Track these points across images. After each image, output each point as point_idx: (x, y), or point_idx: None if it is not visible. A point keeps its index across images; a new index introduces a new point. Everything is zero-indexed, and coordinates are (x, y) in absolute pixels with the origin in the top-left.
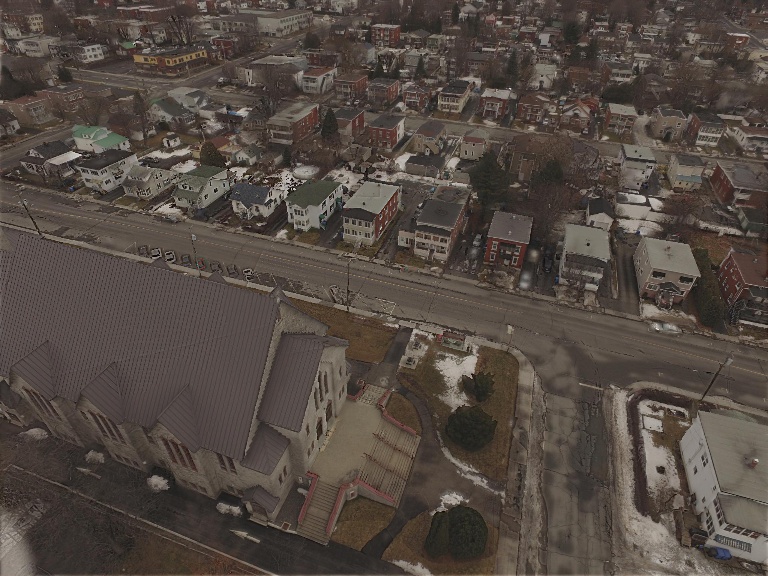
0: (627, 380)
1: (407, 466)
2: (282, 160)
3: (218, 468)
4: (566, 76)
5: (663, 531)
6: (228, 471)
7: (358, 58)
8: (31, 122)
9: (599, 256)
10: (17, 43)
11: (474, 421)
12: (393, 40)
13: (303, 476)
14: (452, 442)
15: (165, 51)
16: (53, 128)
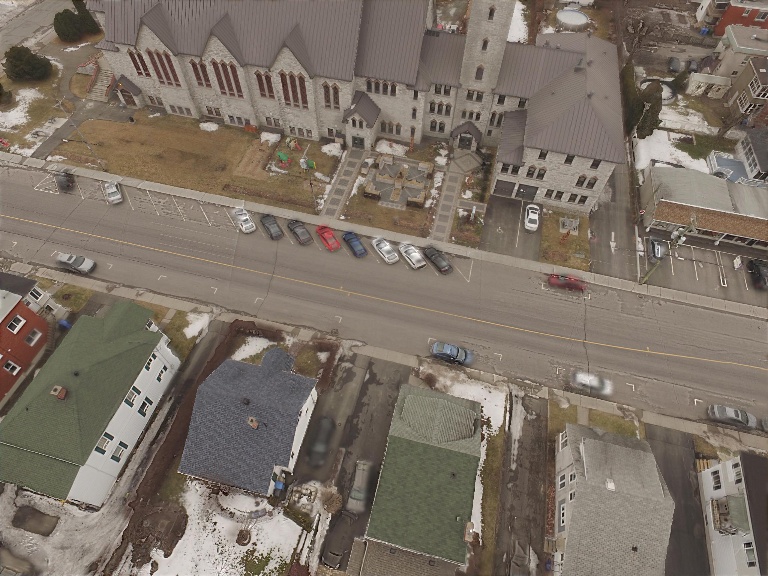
0: None
1: None
2: None
3: None
4: None
5: None
6: None
7: None
8: None
9: None
10: None
11: None
12: None
13: None
14: None
15: None
16: None
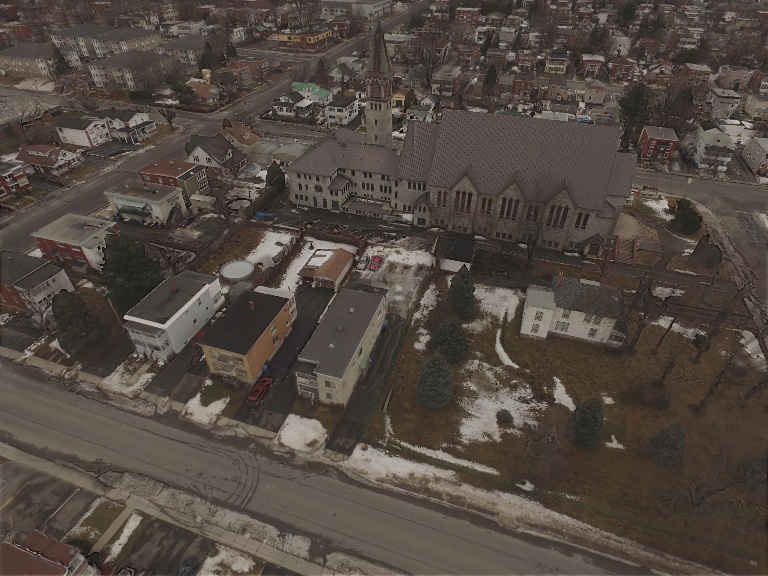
0: (764, 209)
1: (657, 239)
2: (454, 105)
3: (572, 228)
4: (638, 46)
5: None
6: (579, 228)
7: (464, 34)
8: (241, 84)
9: (729, 146)
10: (171, 27)
11: (692, 215)
12: (475, 21)
13: (609, 238)
14: (676, 232)
15: (301, 31)
16: (259, 88)
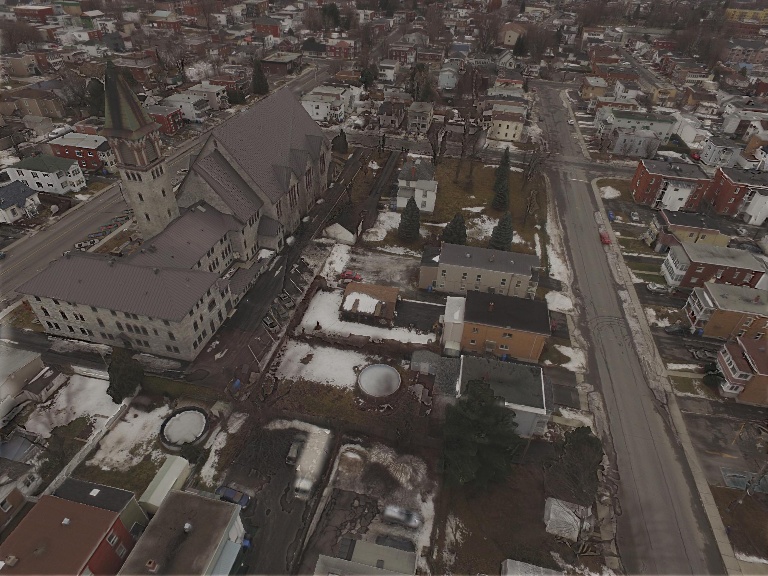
0: None
1: None
2: None
3: None
4: None
5: None
6: None
7: None
8: None
9: None
10: None
11: None
12: None
13: None
14: None
15: None
16: None
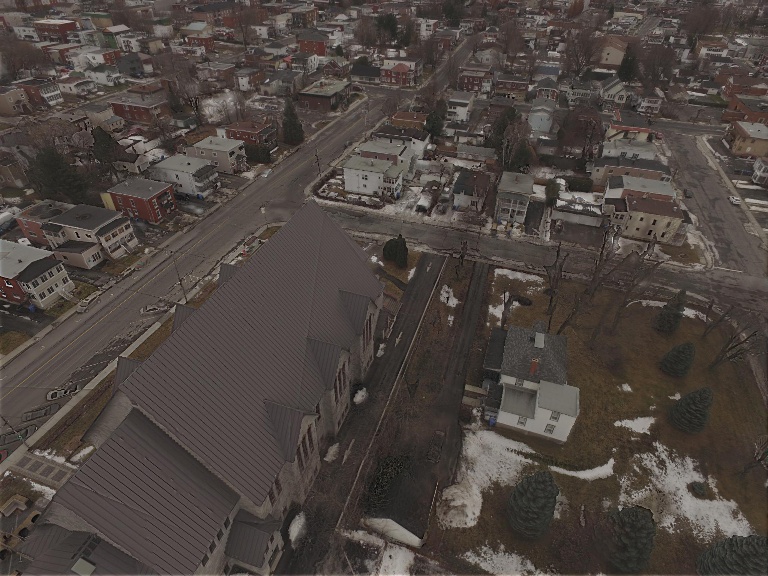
0: (302, 195)
1: None
2: None
3: None
4: None
5: (389, 205)
6: None
7: None
8: None
9: (206, 163)
10: None
11: None
12: None
13: None
14: None
15: None
16: None
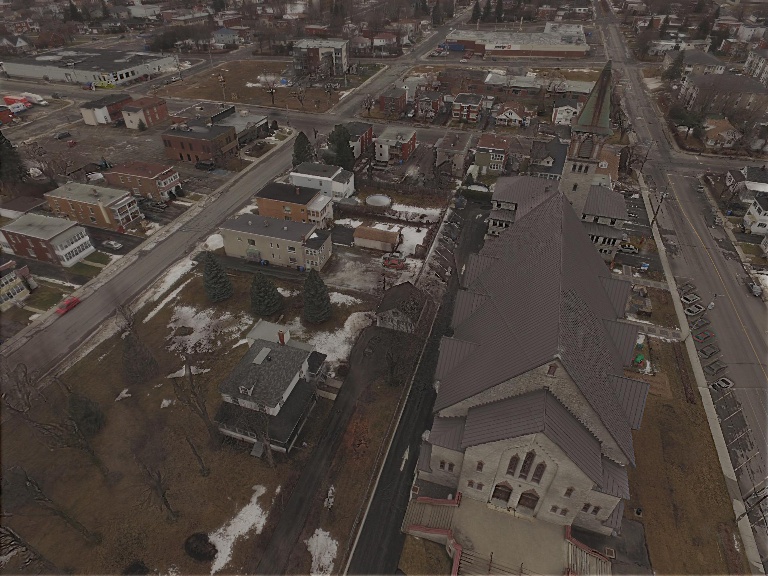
0: None
1: None
2: None
3: None
4: None
5: None
6: None
7: None
8: None
9: None
10: None
11: None
12: None
13: None
14: None
15: None
16: None
